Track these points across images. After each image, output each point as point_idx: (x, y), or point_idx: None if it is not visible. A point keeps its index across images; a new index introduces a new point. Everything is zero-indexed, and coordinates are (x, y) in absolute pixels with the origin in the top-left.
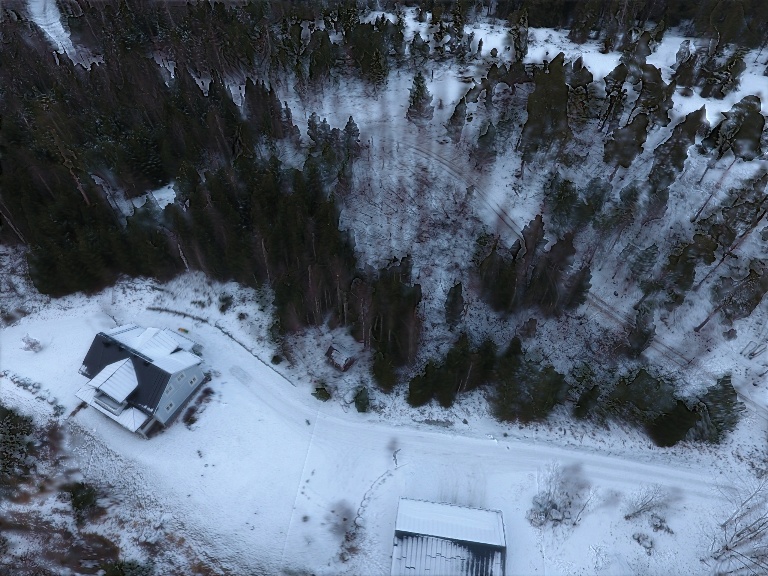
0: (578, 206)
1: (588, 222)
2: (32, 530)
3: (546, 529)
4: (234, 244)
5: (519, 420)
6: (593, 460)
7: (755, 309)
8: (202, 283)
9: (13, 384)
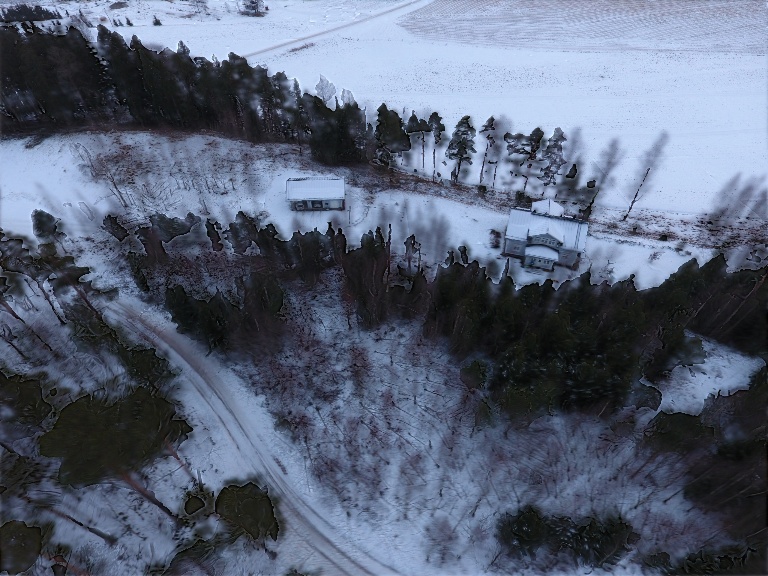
0: None
1: None
2: None
3: None
4: None
5: None
6: None
7: None
8: None
9: None
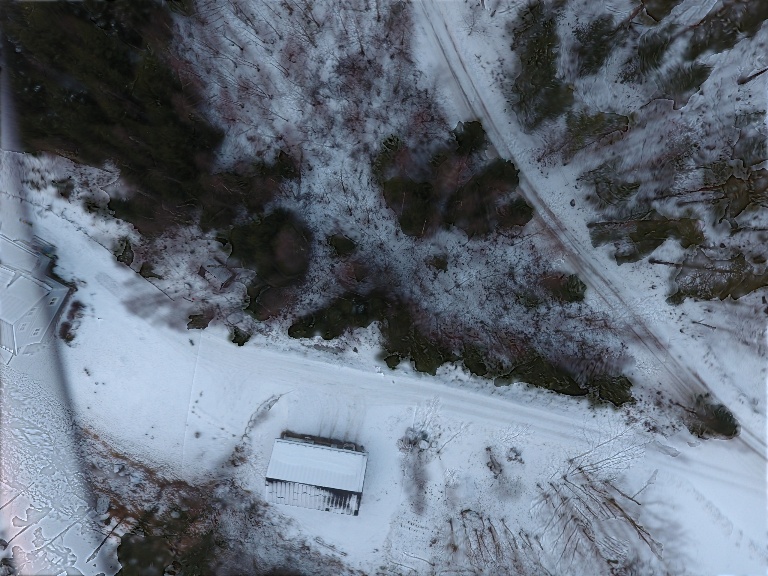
0: (552, 88)
1: (561, 113)
2: None
3: (412, 454)
4: (27, 133)
5: (411, 353)
6: (474, 399)
7: (742, 238)
8: (24, 153)
9: None
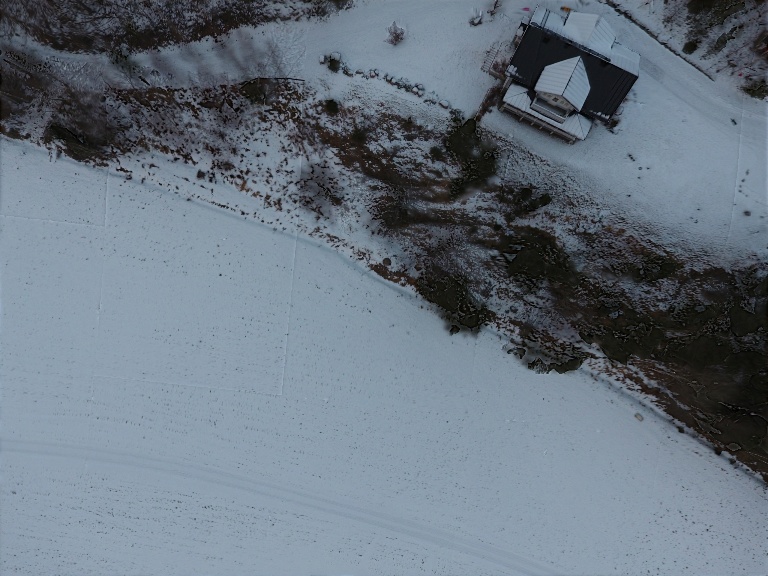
0: None
1: None
2: (449, 222)
3: None
4: None
5: None
6: None
7: None
8: None
9: (391, 86)
